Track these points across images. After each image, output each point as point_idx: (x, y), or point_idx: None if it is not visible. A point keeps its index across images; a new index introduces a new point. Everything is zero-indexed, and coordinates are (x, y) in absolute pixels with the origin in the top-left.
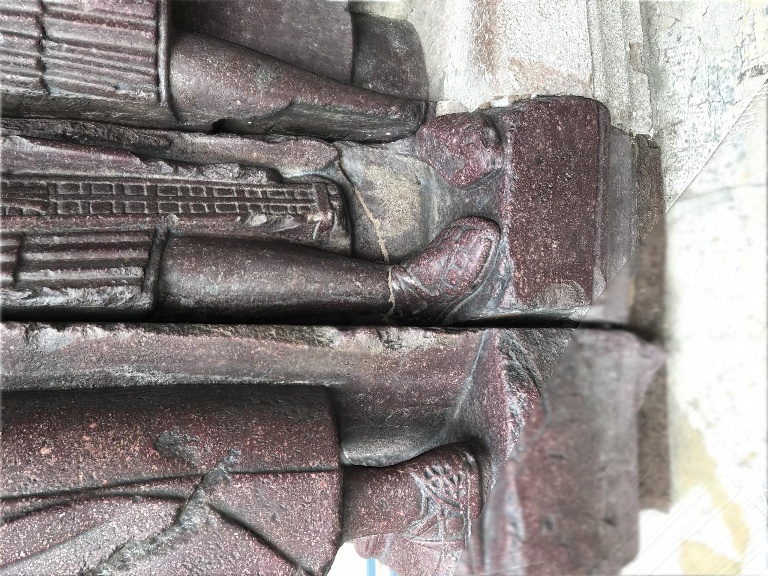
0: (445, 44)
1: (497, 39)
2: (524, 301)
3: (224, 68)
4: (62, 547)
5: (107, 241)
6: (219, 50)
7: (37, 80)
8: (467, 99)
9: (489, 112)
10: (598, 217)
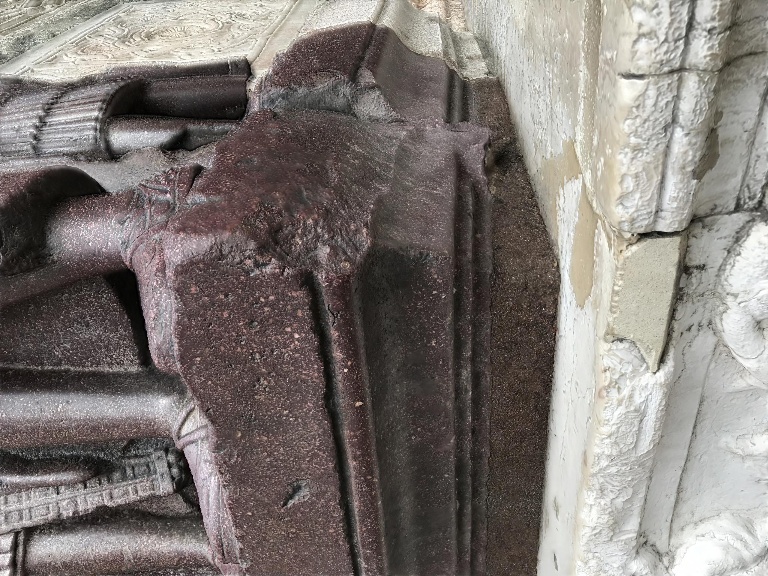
0: None
1: None
2: (277, 84)
3: (140, 118)
4: None
5: None
6: None
7: (29, 143)
8: None
9: None
10: (367, 52)
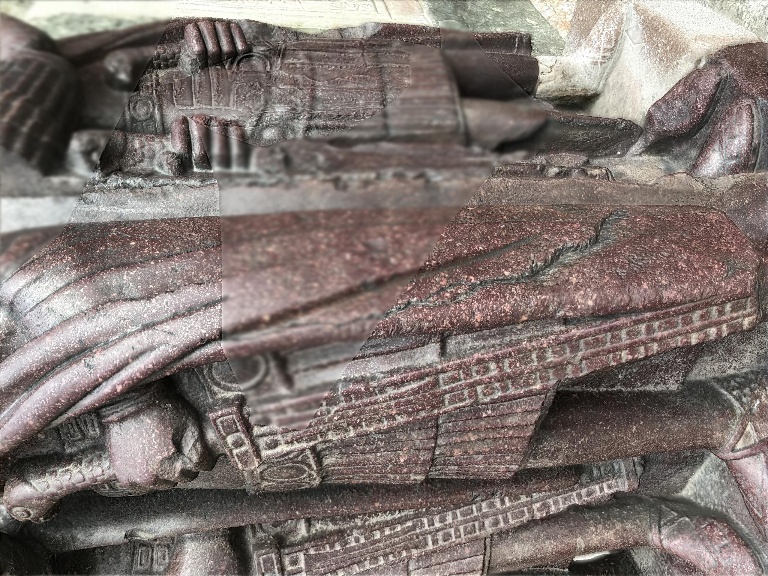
0: (634, 100)
1: (677, 37)
2: None
3: None
4: (509, 251)
5: None
6: None
7: None
8: None
9: None
10: None
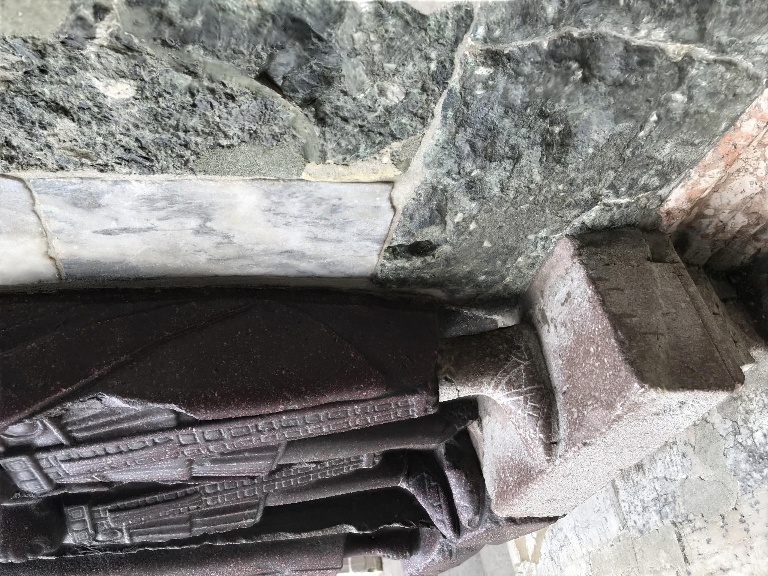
0: (498, 410)
1: (505, 506)
2: None
3: None
4: None
5: (234, 504)
6: (311, 454)
7: None
8: (486, 465)
9: (487, 499)
10: None
